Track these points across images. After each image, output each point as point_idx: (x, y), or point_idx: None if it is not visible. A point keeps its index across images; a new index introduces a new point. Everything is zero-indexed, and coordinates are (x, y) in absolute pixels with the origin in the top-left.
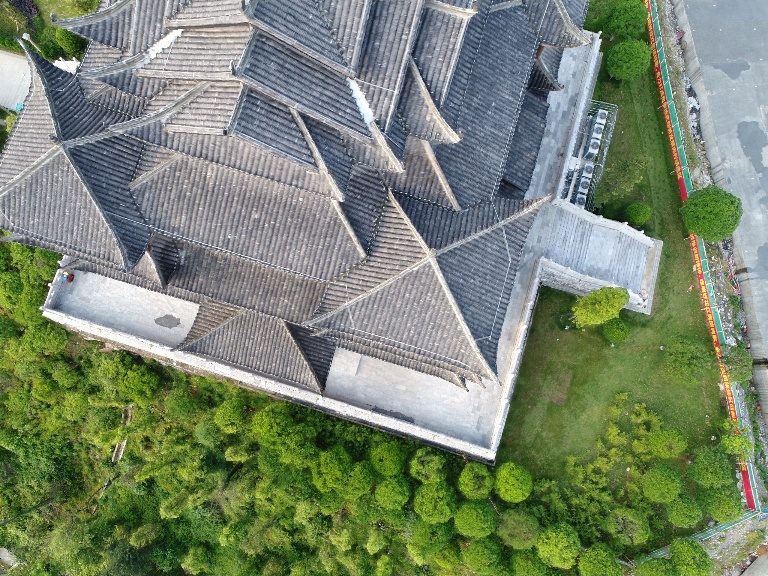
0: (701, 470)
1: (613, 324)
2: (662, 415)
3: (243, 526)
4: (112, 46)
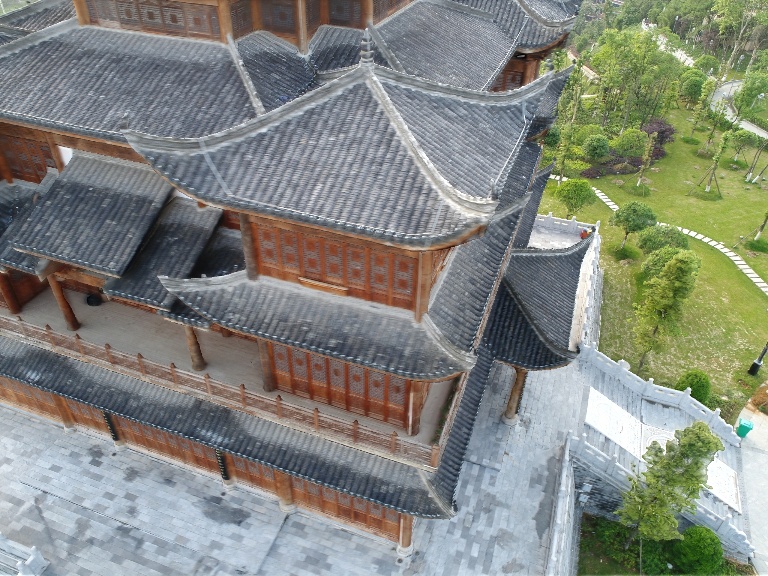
0: None
1: None
2: None
3: None
4: None
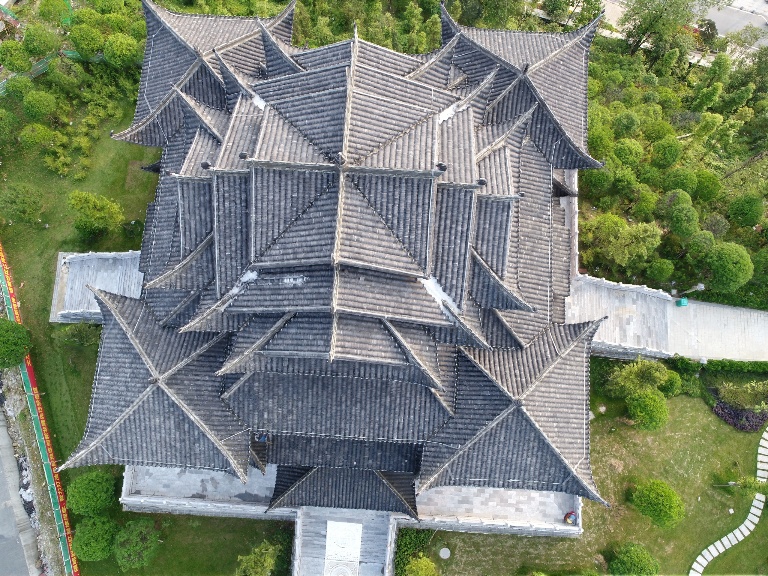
0: (7, 119)
1: (90, 226)
2: (45, 172)
3: (383, 44)
4: (494, 124)
